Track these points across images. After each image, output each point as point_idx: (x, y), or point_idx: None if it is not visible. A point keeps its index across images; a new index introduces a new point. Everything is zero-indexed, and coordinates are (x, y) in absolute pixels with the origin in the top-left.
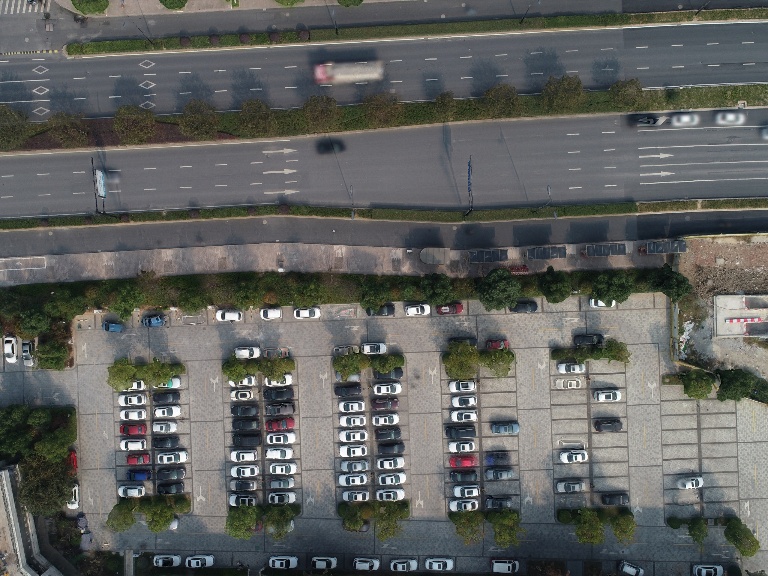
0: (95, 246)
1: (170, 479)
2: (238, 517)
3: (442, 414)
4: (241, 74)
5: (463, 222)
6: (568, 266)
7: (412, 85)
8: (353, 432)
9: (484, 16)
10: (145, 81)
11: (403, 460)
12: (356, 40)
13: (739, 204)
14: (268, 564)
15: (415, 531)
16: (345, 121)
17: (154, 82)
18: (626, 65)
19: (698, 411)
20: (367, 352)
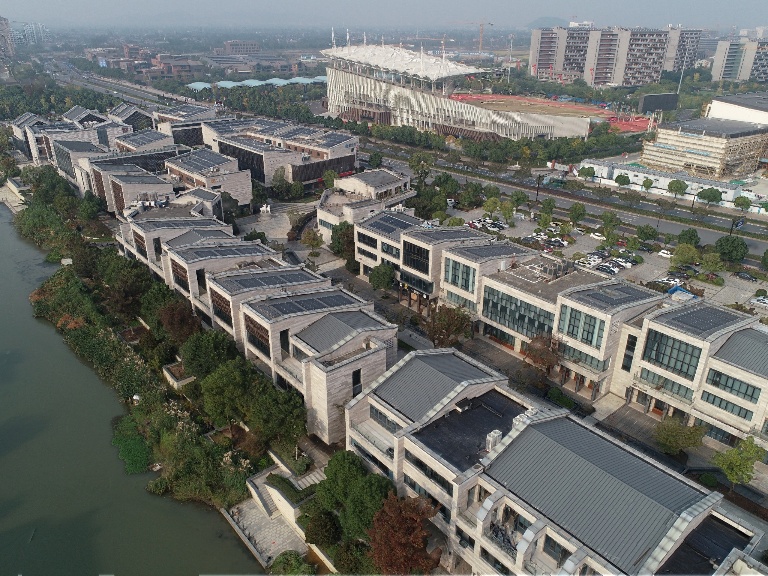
0: None
1: None
2: None
3: None
4: None
5: None
6: None
7: None
8: None
9: None
10: None
11: None
12: None
13: None
14: None
15: None
16: None
17: None
18: None
19: None
20: (622, 251)
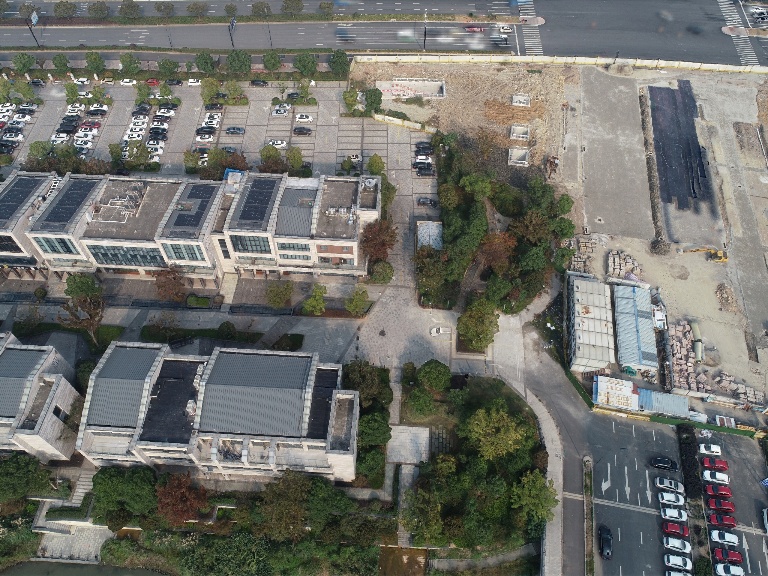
0: None
1: (6, 144)
2: None
3: (197, 126)
4: None
5: None
6: (290, 71)
7: (220, 12)
8: None
9: None
10: (80, 8)
11: (164, 143)
12: None
13: (391, 51)
14: None
15: None
16: (179, 20)
17: (85, 9)
18: (334, 9)
19: (362, 129)
20: (158, 96)
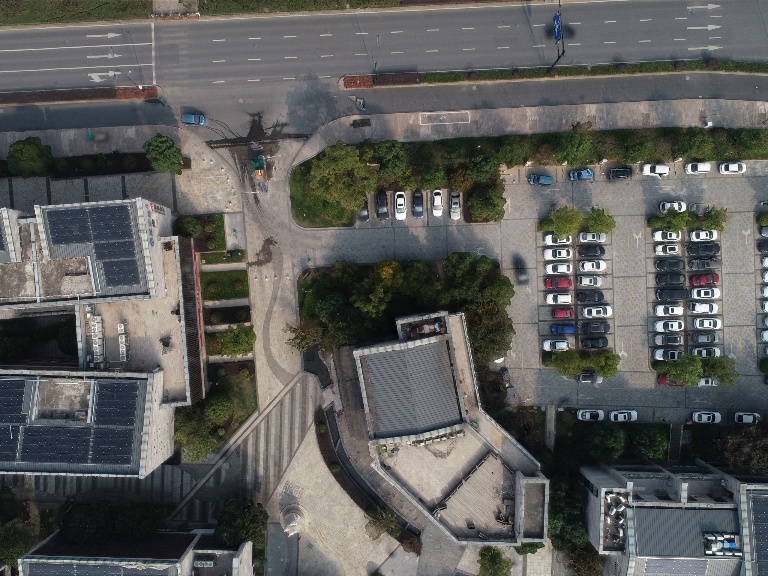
0: (518, 101)
1: (598, 332)
2: (689, 363)
3: None
4: None
5: None
6: None
7: None
8: None
9: None
10: None
11: None
12: None
13: None
14: (690, 419)
15: None
16: None
17: None
18: None
19: None
20: None
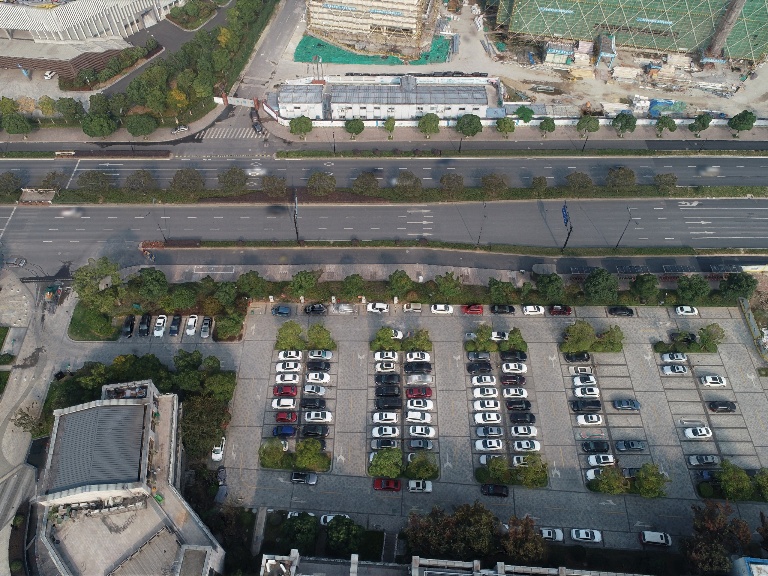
0: (275, 261)
1: (315, 433)
2: (386, 451)
3: (566, 393)
4: (393, 171)
5: (561, 256)
6: None
7: (512, 180)
8: (487, 400)
9: (556, 149)
10: (326, 172)
11: (535, 429)
12: (472, 157)
13: None
14: None
15: (555, 501)
16: (467, 195)
17: (333, 173)
18: None
19: None
20: (495, 337)
